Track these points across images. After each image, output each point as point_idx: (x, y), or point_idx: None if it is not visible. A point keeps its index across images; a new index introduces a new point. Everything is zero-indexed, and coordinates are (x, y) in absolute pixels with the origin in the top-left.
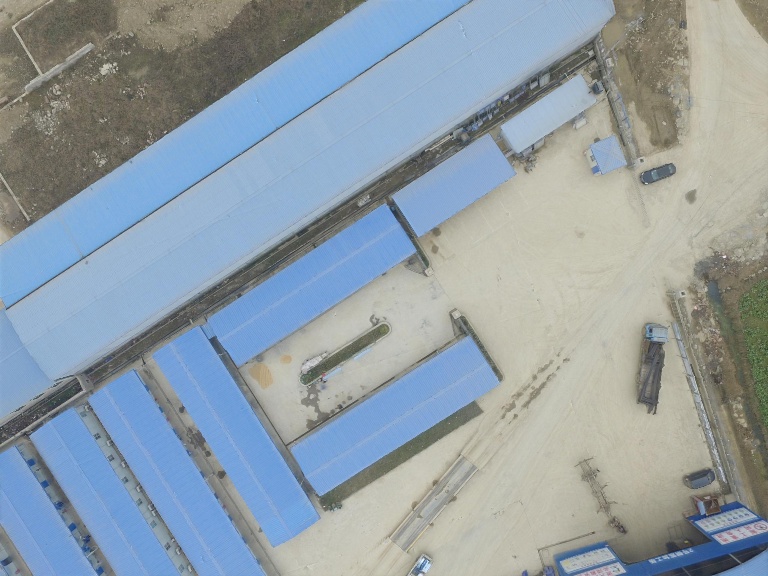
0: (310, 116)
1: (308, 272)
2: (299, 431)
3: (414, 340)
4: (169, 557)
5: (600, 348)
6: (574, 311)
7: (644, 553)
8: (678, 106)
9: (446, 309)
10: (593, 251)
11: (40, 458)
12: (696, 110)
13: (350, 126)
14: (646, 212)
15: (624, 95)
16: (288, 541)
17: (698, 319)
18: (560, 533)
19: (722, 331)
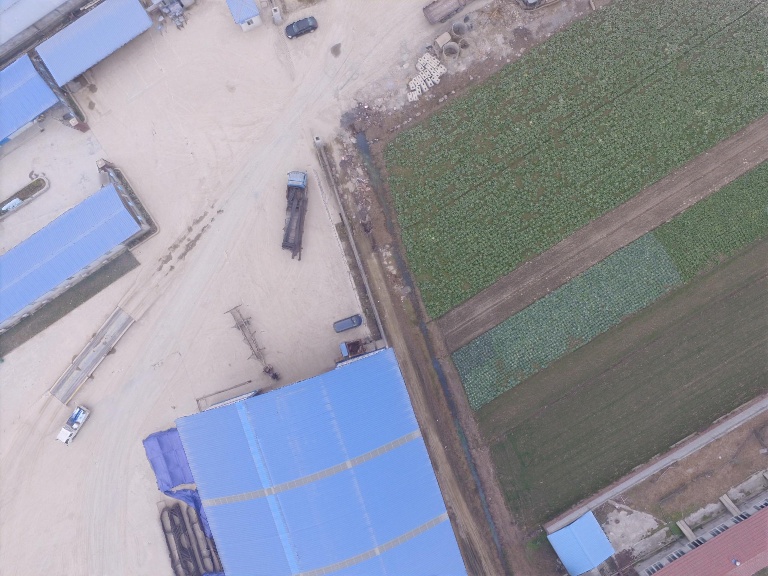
0: None
1: None
2: None
3: (73, 195)
4: None
5: (253, 199)
6: (227, 163)
7: None
8: None
9: None
10: (244, 105)
11: None
12: None
13: None
14: (293, 66)
15: None
16: None
17: (346, 169)
18: (218, 383)
19: (371, 181)
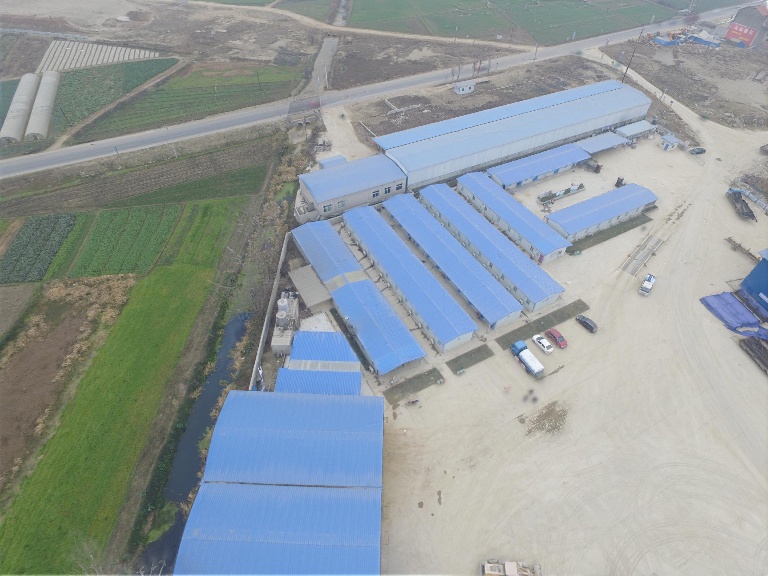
0: None
1: None
2: None
3: (599, 193)
4: None
5: (707, 201)
6: None
7: None
8: (693, 137)
9: (612, 184)
10: (681, 171)
11: None
12: (702, 138)
13: None
14: (700, 162)
15: (666, 133)
16: (549, 269)
17: None
18: (736, 275)
19: None
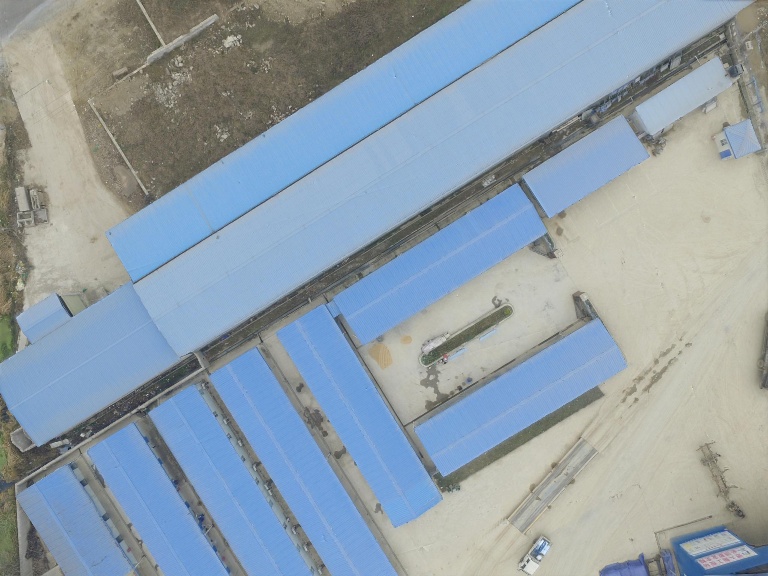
0: (450, 92)
1: (438, 251)
2: (418, 412)
3: (536, 322)
4: (289, 536)
5: (723, 333)
6: (698, 296)
7: (760, 537)
8: None
9: (569, 292)
10: (718, 236)
11: (153, 436)
12: None
13: (492, 103)
14: None
15: None
16: None
17: None
18: (677, 517)
19: None
